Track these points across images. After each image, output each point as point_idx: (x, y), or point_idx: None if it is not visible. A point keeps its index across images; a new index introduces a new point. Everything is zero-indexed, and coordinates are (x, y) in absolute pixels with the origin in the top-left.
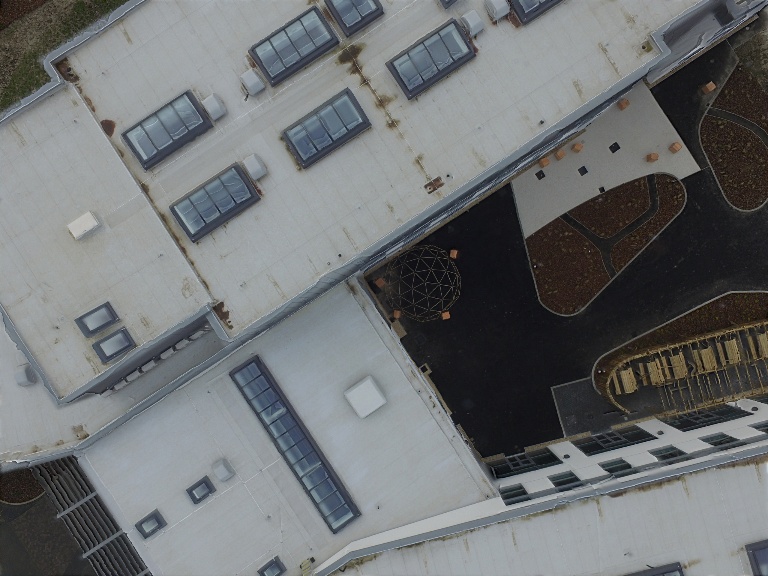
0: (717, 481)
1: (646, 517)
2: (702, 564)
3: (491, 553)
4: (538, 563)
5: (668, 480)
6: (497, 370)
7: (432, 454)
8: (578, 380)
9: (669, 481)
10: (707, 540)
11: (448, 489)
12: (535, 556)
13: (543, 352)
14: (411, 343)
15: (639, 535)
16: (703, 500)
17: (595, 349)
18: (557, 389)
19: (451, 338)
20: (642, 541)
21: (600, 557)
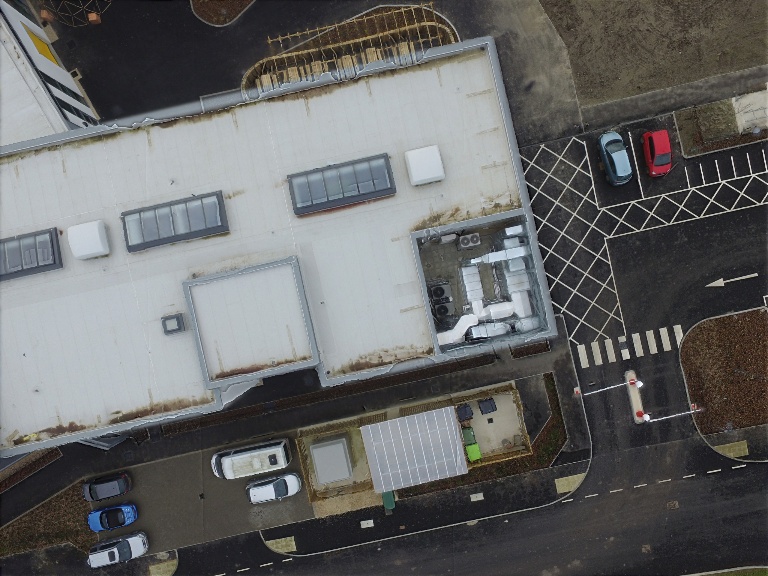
0: (266, 114)
1: (194, 148)
2: (246, 195)
3: (40, 180)
4: (86, 191)
5: (218, 112)
6: (147, 78)
7: (11, 102)
8: (228, 90)
9: (219, 113)
10: (253, 172)
11: (25, 136)
12: (83, 184)
13: (194, 62)
14: (62, 48)
15: (186, 165)
16: (251, 132)
17: (246, 60)
18: (206, 98)
19: (103, 44)
20: (189, 171)
21: (147, 186)
